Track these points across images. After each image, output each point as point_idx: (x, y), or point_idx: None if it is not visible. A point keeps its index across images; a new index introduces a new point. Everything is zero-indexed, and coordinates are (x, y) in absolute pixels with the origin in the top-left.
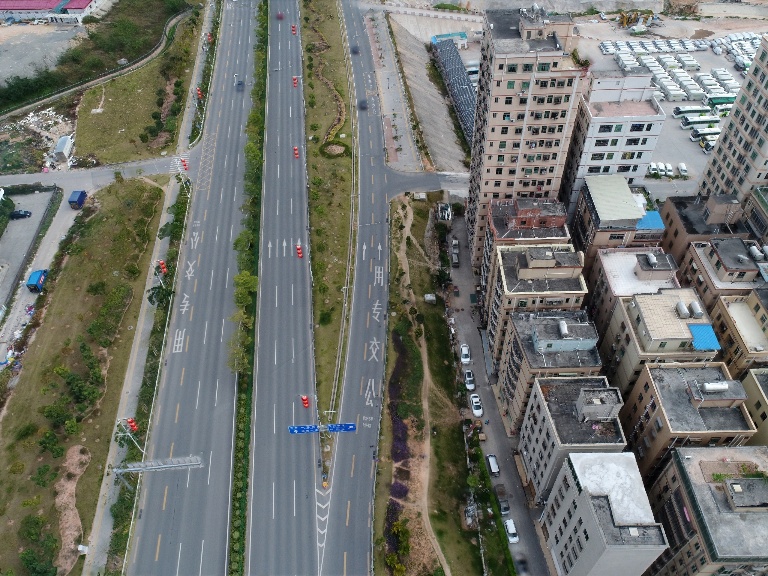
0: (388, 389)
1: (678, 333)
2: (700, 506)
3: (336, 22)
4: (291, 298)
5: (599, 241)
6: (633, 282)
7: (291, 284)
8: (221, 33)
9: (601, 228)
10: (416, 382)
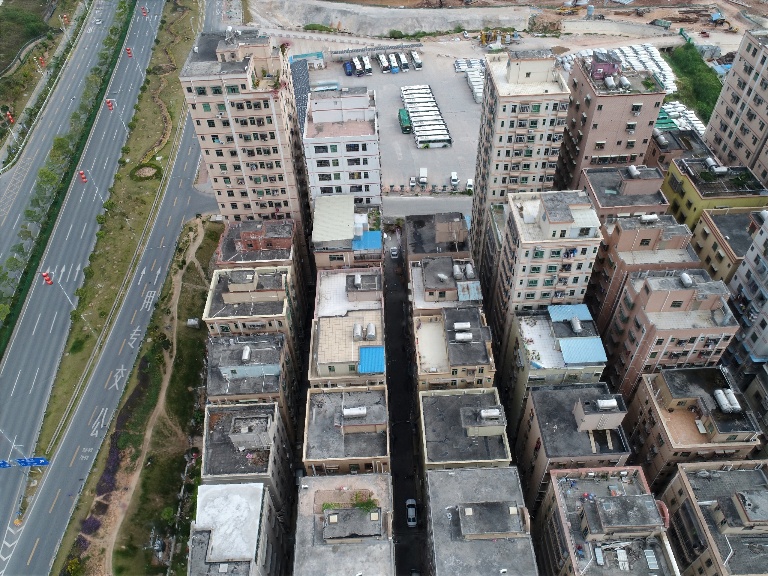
0: (117, 419)
1: (346, 356)
2: (296, 539)
3: (191, 44)
4: (50, 326)
5: (321, 262)
6: (342, 304)
7: (55, 311)
8: (73, 56)
9: (317, 249)
10: (146, 411)
